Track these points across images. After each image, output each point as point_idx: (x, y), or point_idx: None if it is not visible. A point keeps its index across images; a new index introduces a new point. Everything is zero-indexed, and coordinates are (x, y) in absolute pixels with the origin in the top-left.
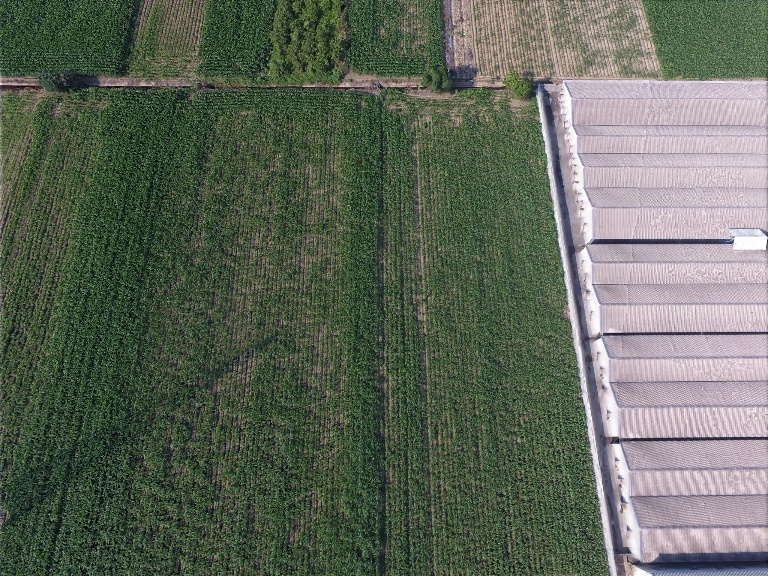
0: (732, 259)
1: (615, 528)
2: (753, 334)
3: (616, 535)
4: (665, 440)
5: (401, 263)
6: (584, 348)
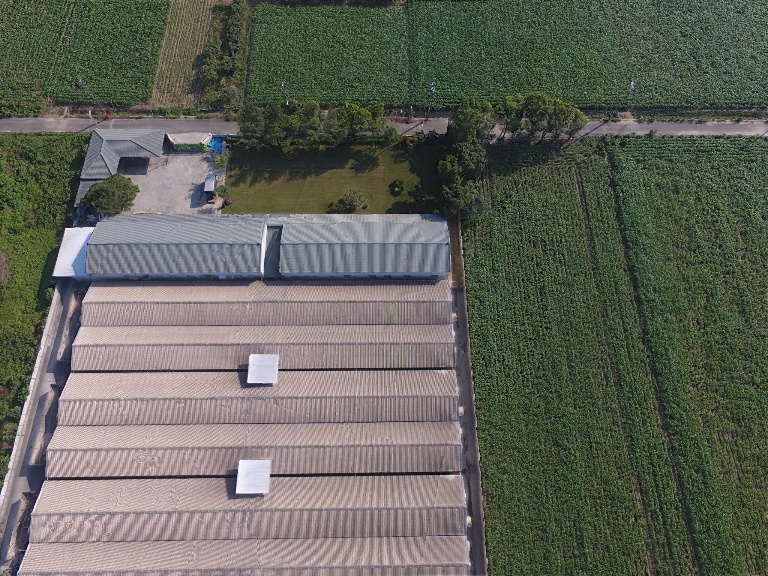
0: (299, 573)
1: (455, 305)
2: (300, 474)
3: (455, 300)
4: (414, 368)
5: (673, 567)
6: (468, 461)
